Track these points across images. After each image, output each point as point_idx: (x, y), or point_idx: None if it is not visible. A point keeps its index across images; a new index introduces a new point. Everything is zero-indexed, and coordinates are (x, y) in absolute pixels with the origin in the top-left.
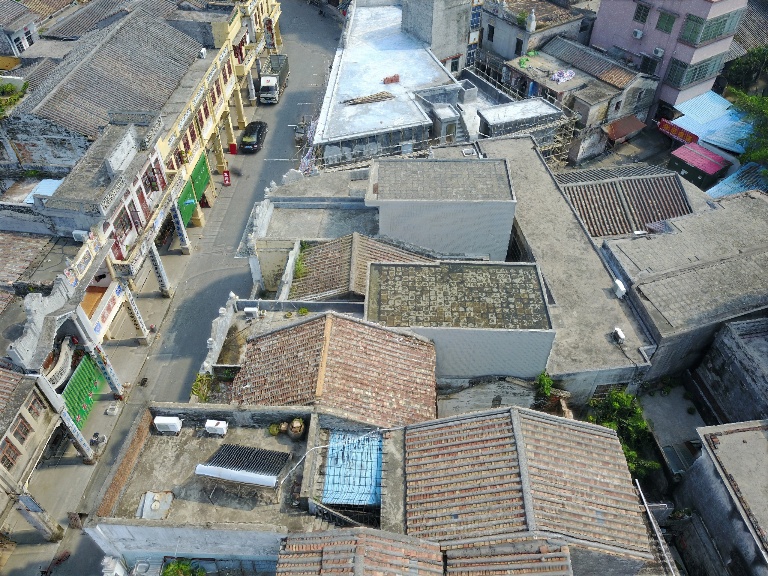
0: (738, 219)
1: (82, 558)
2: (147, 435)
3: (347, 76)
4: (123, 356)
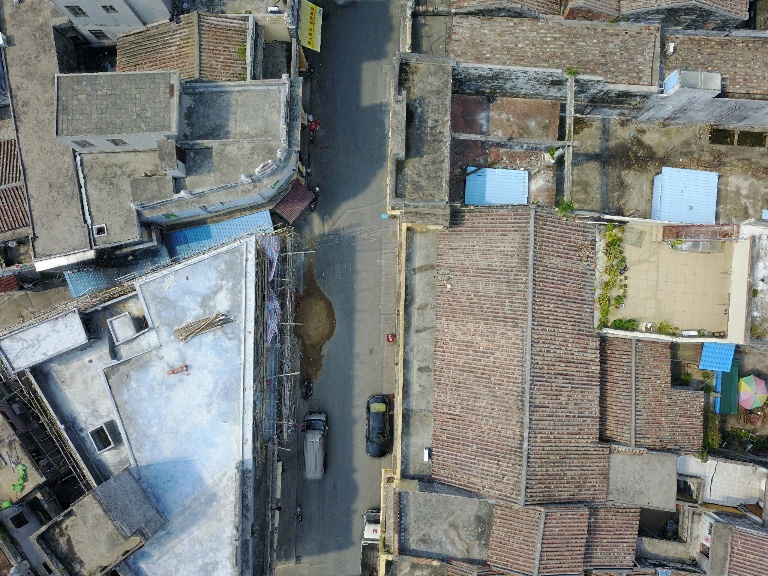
0: None
1: None
2: None
3: (232, 384)
4: None
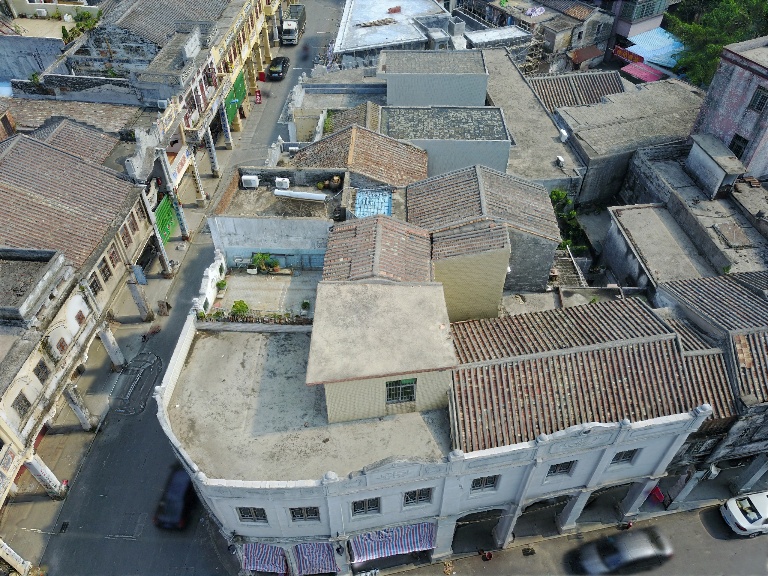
0: (657, 95)
1: (170, 331)
2: (237, 187)
3: (358, 8)
4: (186, 214)
